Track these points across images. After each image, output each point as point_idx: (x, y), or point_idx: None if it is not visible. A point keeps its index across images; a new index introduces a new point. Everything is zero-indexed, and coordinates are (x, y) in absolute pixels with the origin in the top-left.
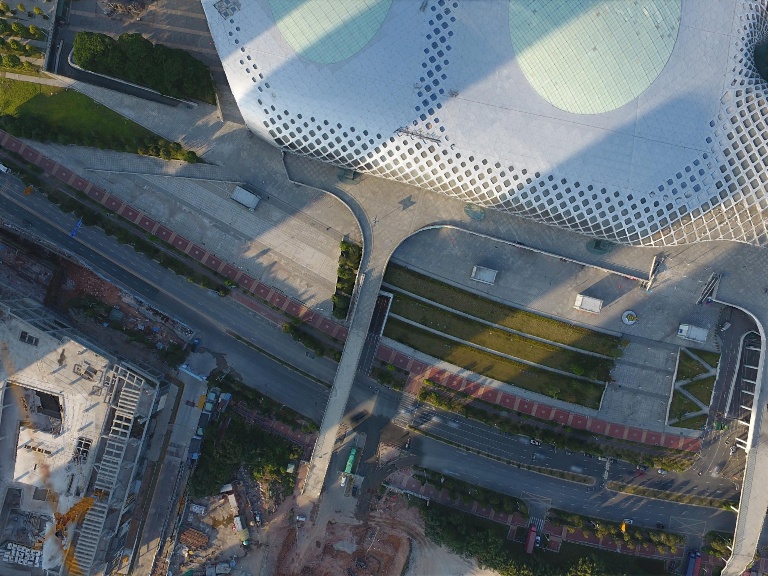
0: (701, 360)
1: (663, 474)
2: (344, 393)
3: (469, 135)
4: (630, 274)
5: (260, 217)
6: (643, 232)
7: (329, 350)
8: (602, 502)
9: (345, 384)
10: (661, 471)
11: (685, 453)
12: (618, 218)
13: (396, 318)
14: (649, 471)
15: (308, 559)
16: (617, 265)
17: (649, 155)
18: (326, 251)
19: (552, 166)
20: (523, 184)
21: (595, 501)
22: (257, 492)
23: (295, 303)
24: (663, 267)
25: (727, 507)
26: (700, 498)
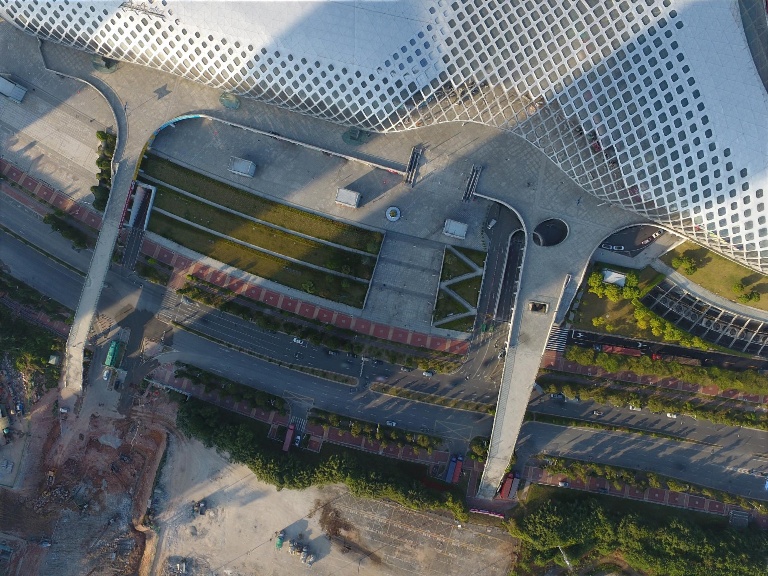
0: (468, 259)
1: (428, 376)
2: (98, 283)
3: (191, 9)
4: (387, 166)
5: (27, 109)
6: (380, 114)
7: (94, 244)
8: (365, 403)
9: (99, 274)
10: (426, 373)
11: (452, 356)
12: (351, 98)
13: (160, 212)
14: (415, 373)
15: (71, 451)
16: (374, 157)
17: (372, 27)
18: (91, 144)
19: (276, 41)
20: (252, 62)
21: (358, 402)
22: (20, 382)
23: (62, 196)
24: (424, 160)
25: (493, 412)
26: (467, 402)
